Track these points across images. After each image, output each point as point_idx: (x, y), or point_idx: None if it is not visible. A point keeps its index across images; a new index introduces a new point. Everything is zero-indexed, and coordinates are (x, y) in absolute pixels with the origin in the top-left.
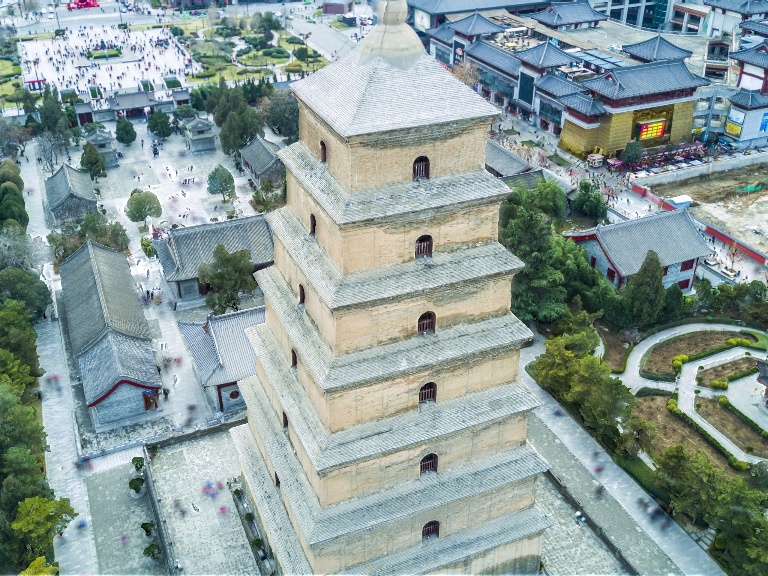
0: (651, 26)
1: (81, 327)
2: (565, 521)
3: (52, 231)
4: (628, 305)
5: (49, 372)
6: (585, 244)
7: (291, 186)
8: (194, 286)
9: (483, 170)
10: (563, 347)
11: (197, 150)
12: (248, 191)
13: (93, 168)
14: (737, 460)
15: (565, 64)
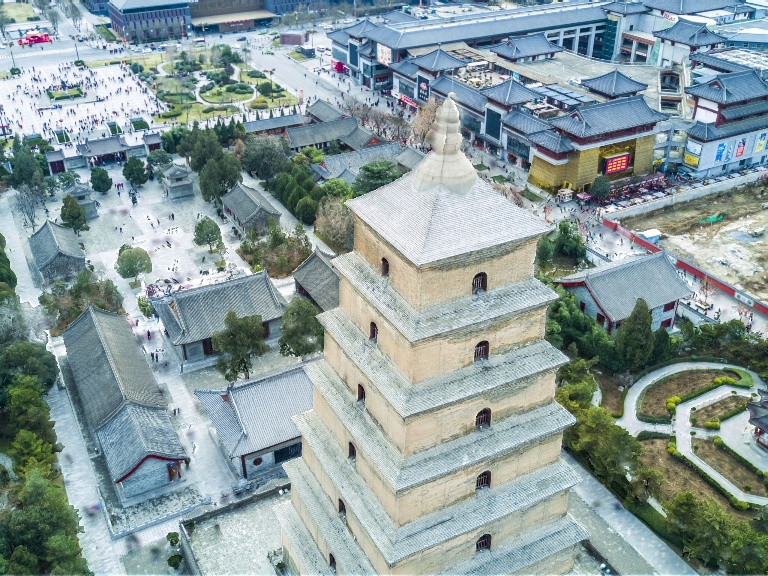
0: (605, 57)
1: (95, 399)
2: (592, 574)
3: (44, 292)
4: (621, 350)
5: (65, 445)
6: (574, 290)
7: (346, 291)
8: (199, 347)
9: (532, 278)
10: (567, 398)
11: (176, 197)
12: (233, 239)
13: (75, 222)
14: (738, 500)
15: (530, 101)
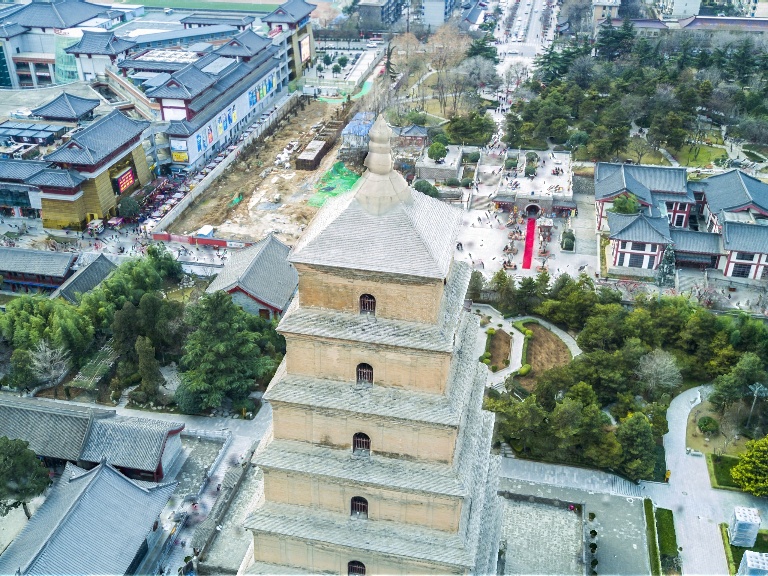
0: (25, 84)
1: None
2: None
3: None
4: None
5: None
6: None
7: (301, 353)
8: None
9: None
10: None
11: None
12: None
13: None
14: None
15: None
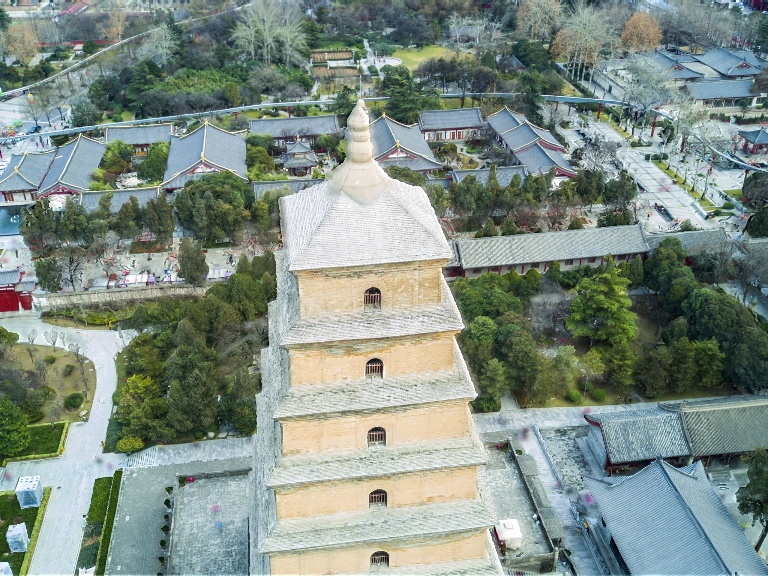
0: None
1: None
2: None
3: None
4: None
5: None
6: None
7: None
8: None
9: None
10: None
11: None
12: None
13: None
14: None
15: None
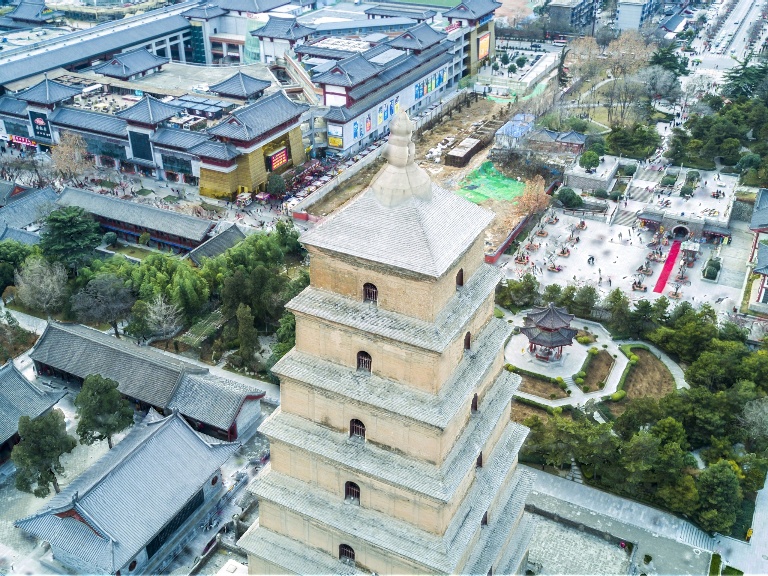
0: (212, 62)
1: None
2: None
3: None
4: None
5: None
6: None
7: (308, 332)
8: None
9: None
10: None
11: None
12: None
13: None
14: (553, 408)
15: (173, 115)
